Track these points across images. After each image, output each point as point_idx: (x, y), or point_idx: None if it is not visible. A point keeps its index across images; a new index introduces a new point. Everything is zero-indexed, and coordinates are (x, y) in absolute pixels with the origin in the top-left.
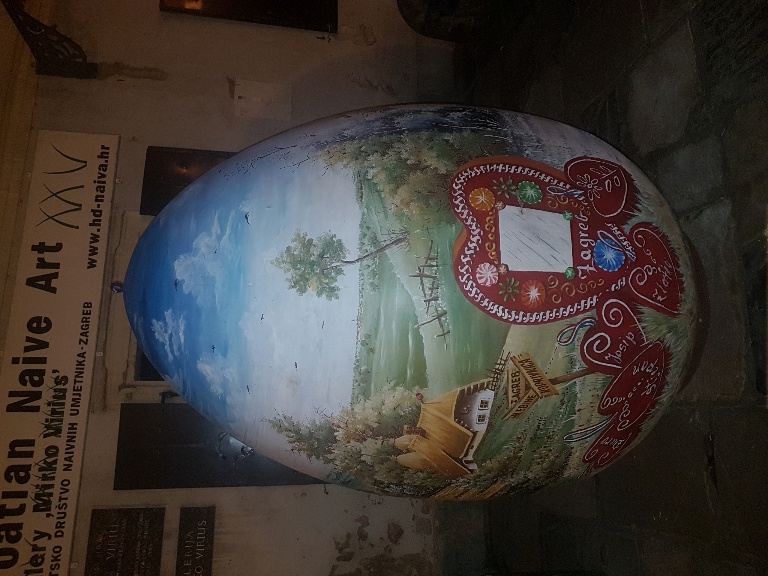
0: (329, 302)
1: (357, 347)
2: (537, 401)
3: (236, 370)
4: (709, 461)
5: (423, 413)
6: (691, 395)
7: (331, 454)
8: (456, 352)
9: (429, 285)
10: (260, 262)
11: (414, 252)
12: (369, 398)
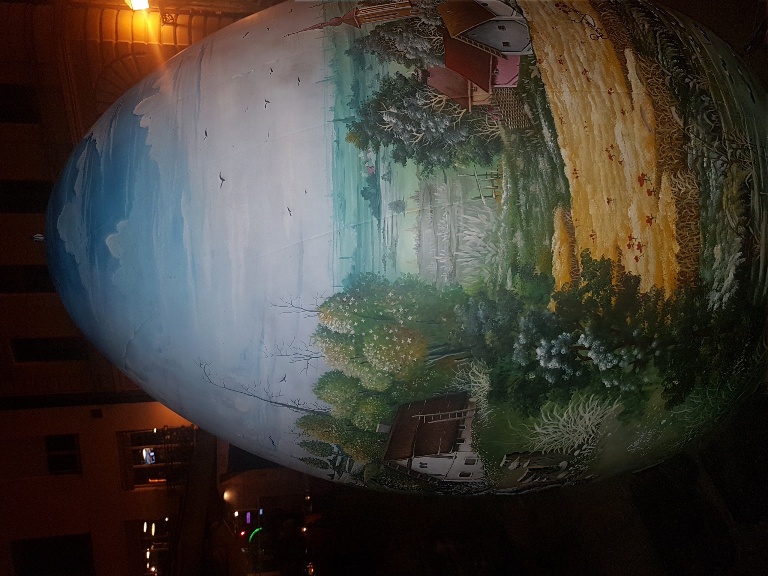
0: None
1: None
2: None
3: None
4: (767, 26)
5: None
6: None
7: None
8: None
9: None
10: None
11: None
12: None
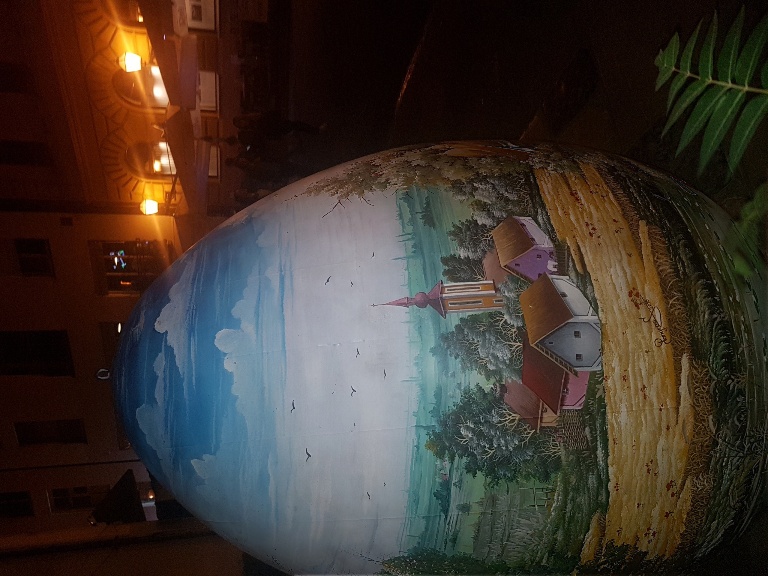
0: None
1: None
2: None
3: None
4: None
5: None
6: None
7: (381, 177)
8: None
9: None
10: None
11: None
12: None
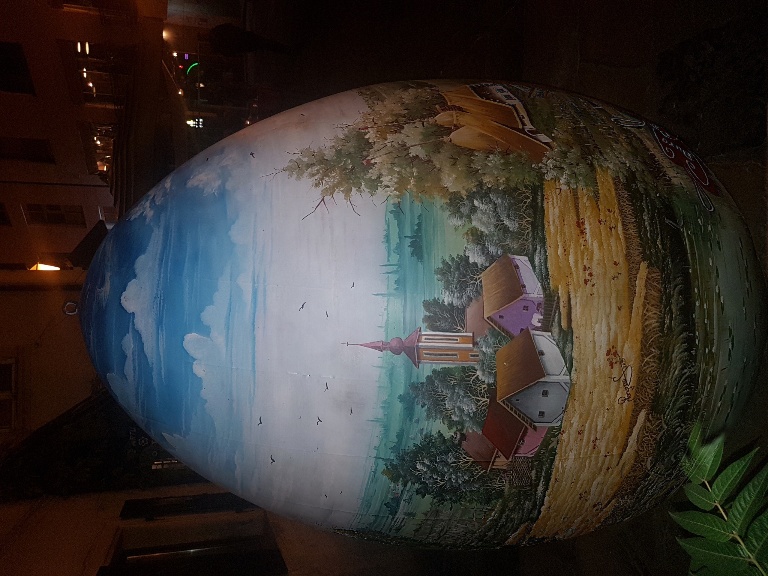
0: None
1: None
2: None
3: None
4: None
5: (447, 97)
6: (761, 239)
7: (373, 169)
8: None
9: None
10: None
11: None
12: (385, 100)
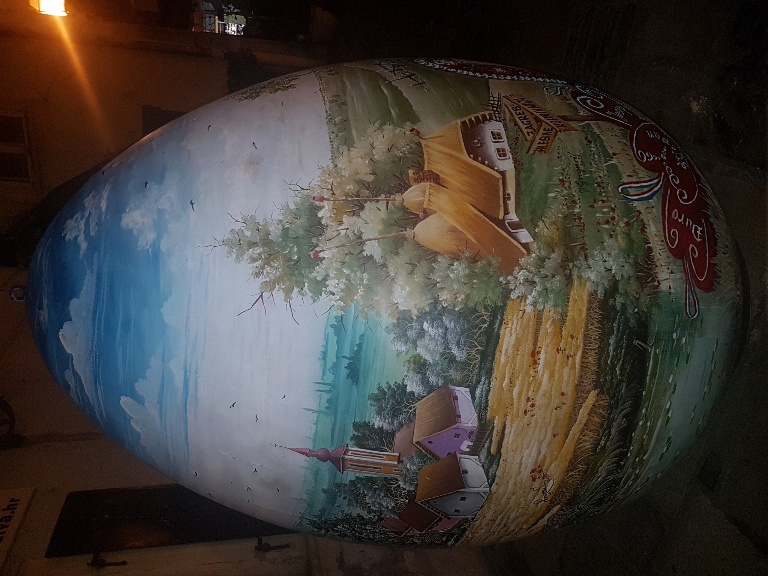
0: (286, 92)
1: (325, 106)
2: (557, 135)
3: (176, 190)
4: None
5: (426, 151)
6: (760, 284)
7: (320, 266)
8: (440, 93)
9: (389, 66)
10: (205, 108)
11: (366, 61)
12: (353, 146)
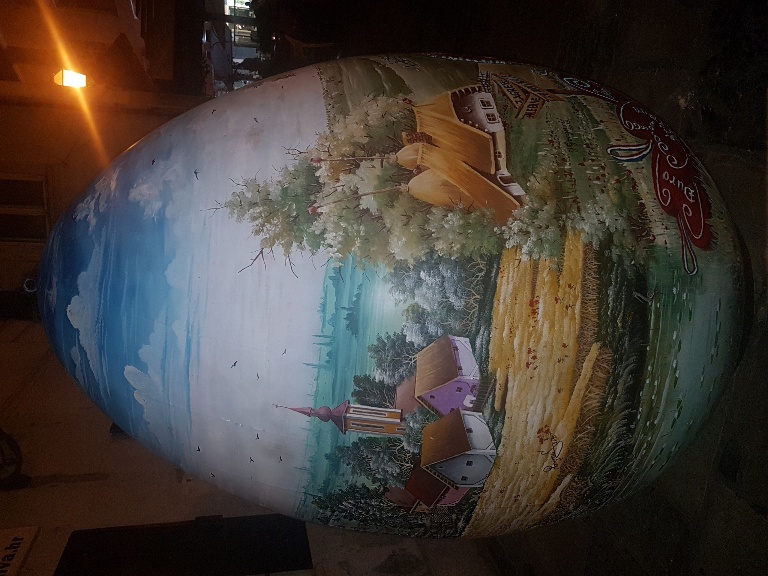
0: (286, 79)
1: (323, 85)
2: (545, 104)
3: (181, 164)
4: None
5: (419, 116)
6: (763, 261)
7: (318, 221)
8: (431, 71)
9: None
10: None
11: None
12: (349, 114)
